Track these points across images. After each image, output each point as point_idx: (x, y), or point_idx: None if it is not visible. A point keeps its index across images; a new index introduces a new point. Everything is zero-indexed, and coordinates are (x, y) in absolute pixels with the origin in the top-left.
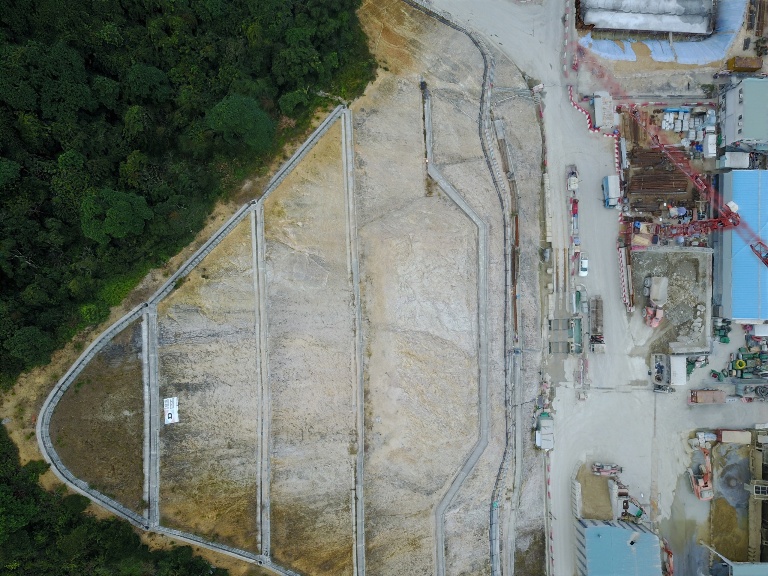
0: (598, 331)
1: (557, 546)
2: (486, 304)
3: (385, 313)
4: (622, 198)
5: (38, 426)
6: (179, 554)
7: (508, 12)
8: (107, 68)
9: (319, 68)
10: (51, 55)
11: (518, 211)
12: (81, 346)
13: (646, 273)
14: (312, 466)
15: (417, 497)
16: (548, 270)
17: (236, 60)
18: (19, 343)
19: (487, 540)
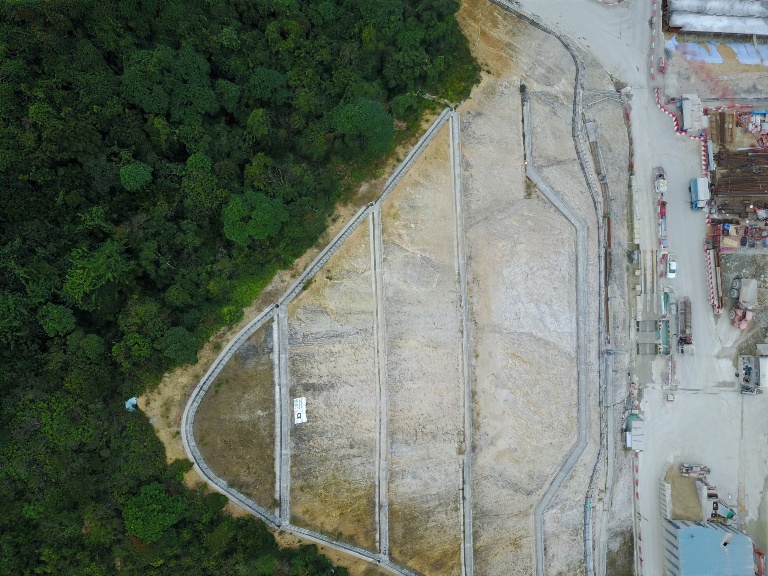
0: (686, 333)
1: (645, 547)
2: (585, 306)
3: (492, 314)
4: (709, 200)
5: (183, 425)
6: (307, 552)
7: (596, 15)
8: (224, 71)
9: (430, 71)
10: (181, 59)
11: (610, 213)
12: (220, 346)
13: (734, 275)
14: (424, 466)
15: (518, 497)
16: (636, 272)
17: (350, 63)
18: (171, 343)
19: (581, 540)
